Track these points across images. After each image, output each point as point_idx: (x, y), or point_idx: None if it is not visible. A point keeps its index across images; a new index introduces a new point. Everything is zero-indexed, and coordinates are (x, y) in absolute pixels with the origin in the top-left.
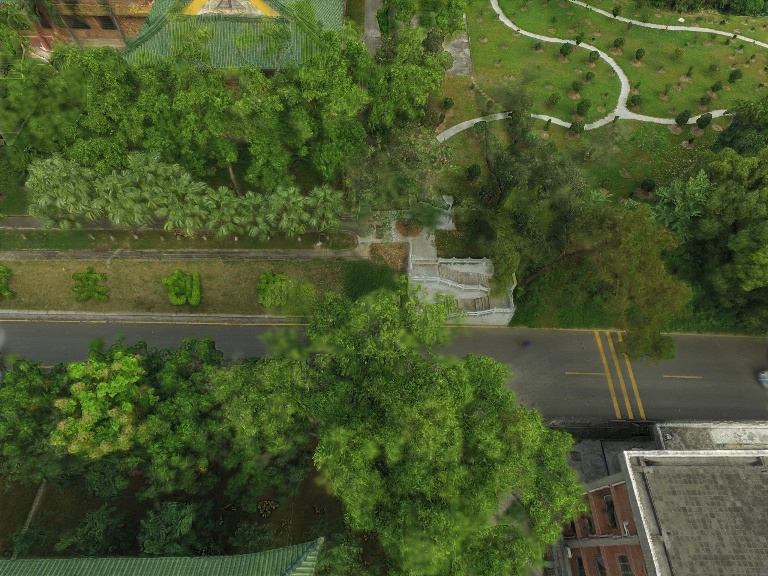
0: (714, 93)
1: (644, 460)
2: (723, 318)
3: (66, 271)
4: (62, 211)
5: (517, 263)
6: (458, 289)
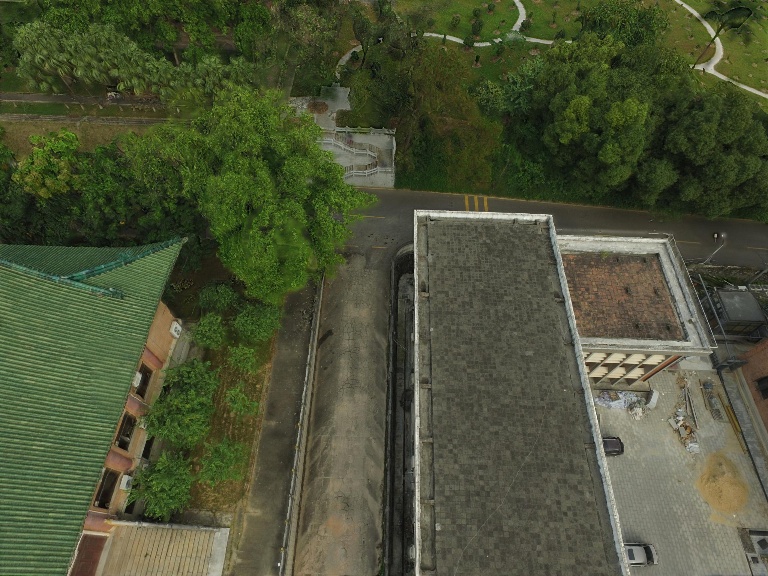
0: None
1: (431, 219)
2: (571, 188)
3: (46, 130)
4: (41, 72)
5: (365, 98)
6: (351, 153)
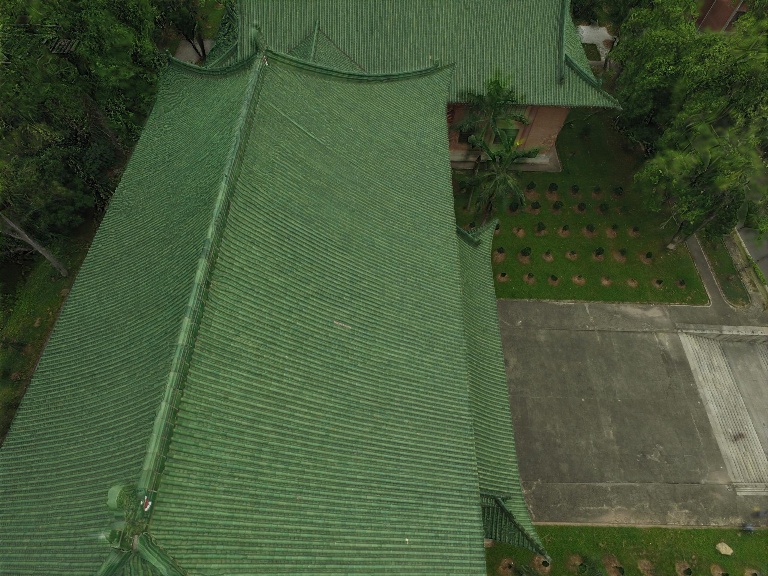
0: None
1: None
2: None
3: None
4: None
5: None
6: None
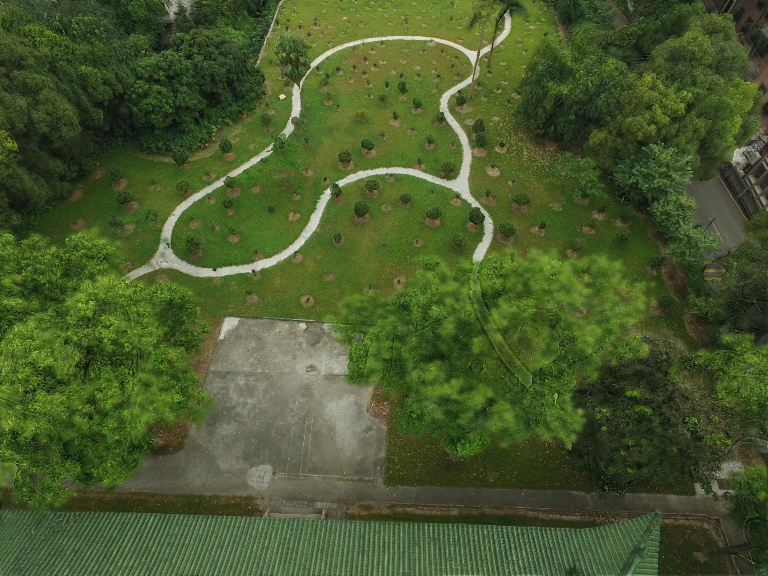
0: (417, 109)
1: None
2: None
3: None
4: None
5: None
6: None
